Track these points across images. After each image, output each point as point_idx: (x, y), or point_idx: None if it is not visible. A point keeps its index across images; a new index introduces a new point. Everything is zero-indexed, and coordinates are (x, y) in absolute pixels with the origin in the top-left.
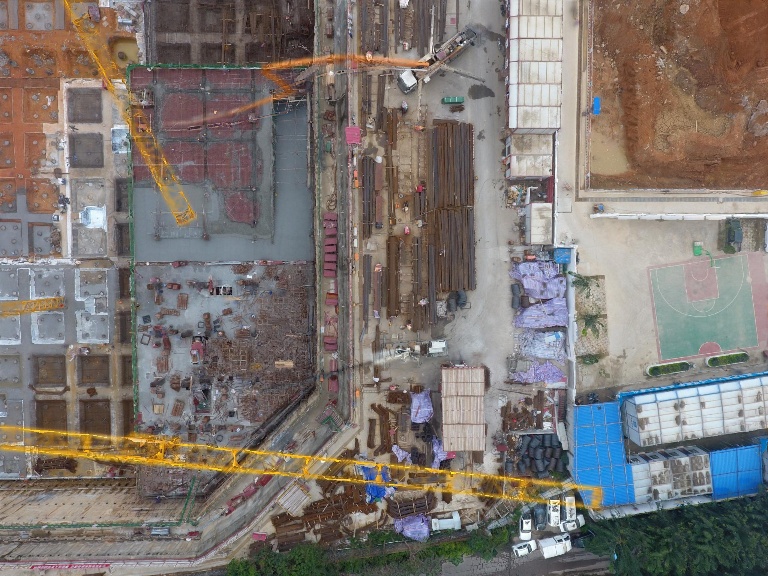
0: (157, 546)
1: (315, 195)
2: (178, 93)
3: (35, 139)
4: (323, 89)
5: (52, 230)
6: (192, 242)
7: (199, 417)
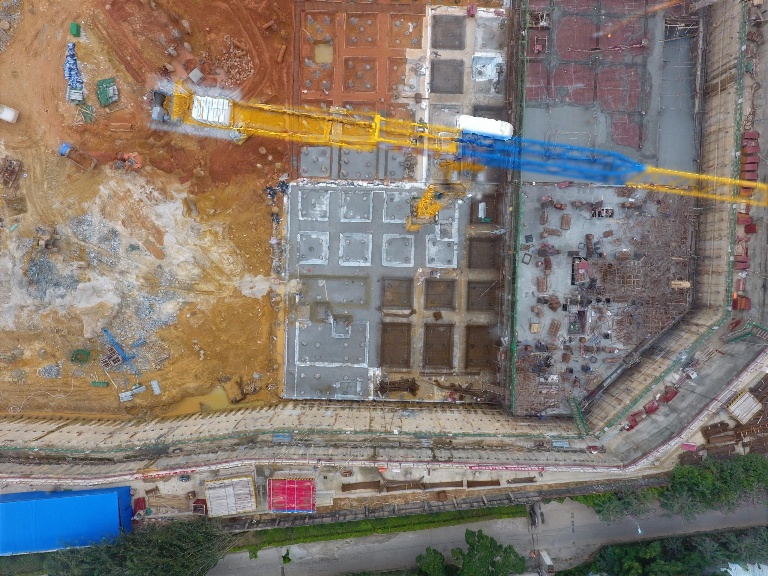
0: (572, 456)
1: (701, 121)
2: (573, 16)
3: (395, 64)
4: (747, 10)
5: (406, 155)
6: (578, 163)
7: (574, 338)
